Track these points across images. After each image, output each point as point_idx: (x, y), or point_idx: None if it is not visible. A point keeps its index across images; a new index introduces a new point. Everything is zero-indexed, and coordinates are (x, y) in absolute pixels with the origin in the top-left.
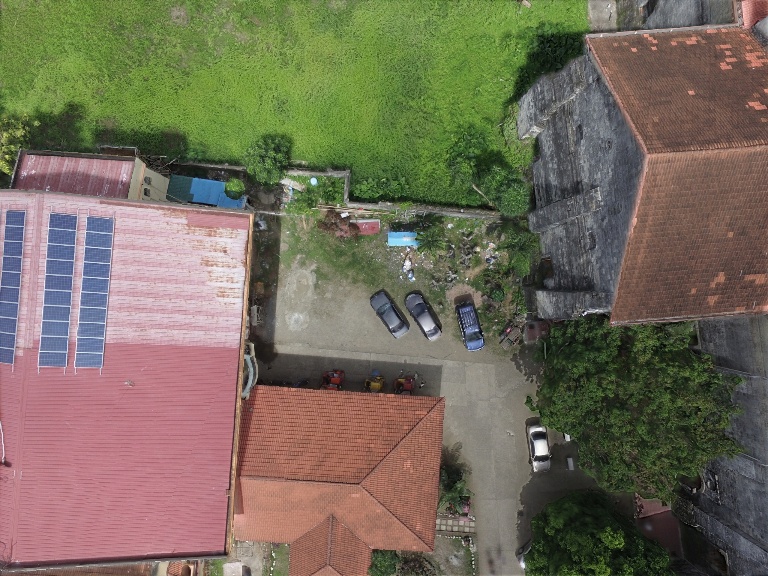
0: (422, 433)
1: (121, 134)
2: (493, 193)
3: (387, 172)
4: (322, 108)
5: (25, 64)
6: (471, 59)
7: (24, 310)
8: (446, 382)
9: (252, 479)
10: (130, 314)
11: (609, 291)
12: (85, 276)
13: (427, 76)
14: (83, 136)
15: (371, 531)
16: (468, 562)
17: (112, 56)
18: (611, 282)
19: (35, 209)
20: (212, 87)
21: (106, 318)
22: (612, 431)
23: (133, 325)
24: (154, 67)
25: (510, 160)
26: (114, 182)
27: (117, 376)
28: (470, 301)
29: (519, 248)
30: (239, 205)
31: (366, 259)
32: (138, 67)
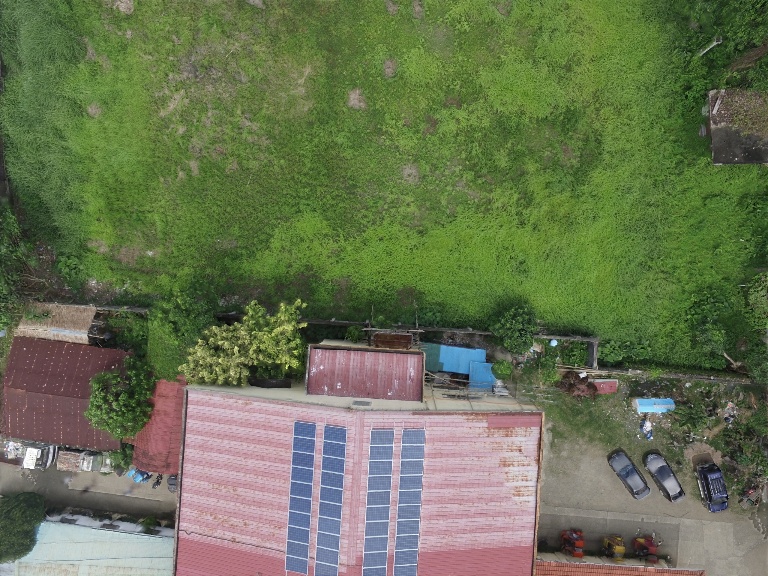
0: None
1: (357, 294)
2: None
3: (631, 336)
4: (561, 269)
5: (259, 224)
6: (709, 218)
7: (346, 526)
8: (684, 541)
9: None
10: (438, 522)
11: None
12: (401, 489)
13: (663, 234)
14: (320, 296)
15: None
16: None
17: (346, 215)
18: None
19: (356, 426)
20: (447, 246)
21: (419, 529)
22: None
23: (441, 532)
24: (389, 227)
25: (752, 321)
26: (403, 377)
27: None
28: (715, 464)
29: None
30: (493, 376)
31: (603, 418)
32: (372, 226)
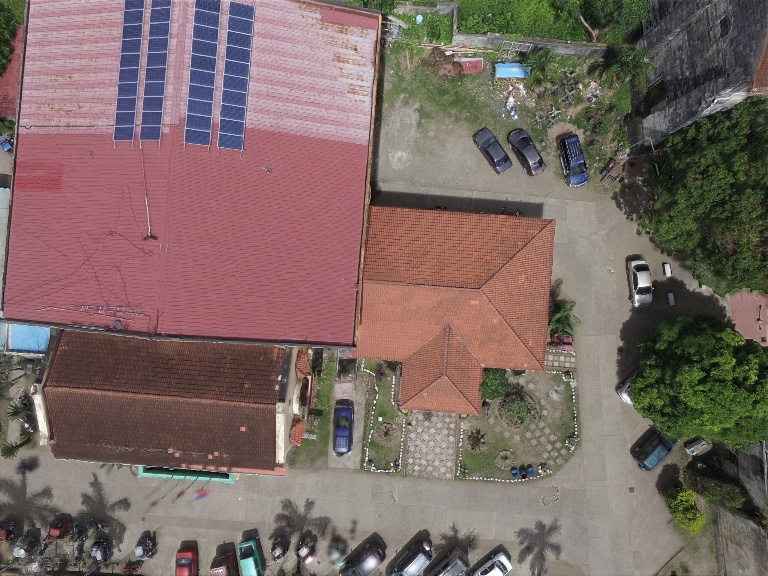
0: (535, 250)
1: None
2: (611, 6)
3: (493, 7)
4: None
5: None
6: None
7: (170, 89)
8: None
9: (375, 283)
10: (268, 102)
11: (748, 64)
12: (228, 59)
13: None
14: None
15: (485, 345)
16: (568, 397)
17: None
18: (751, 53)
19: None
20: None
21: (246, 102)
22: (742, 217)
23: (270, 113)
24: None
25: None
26: None
27: (255, 161)
28: None
29: (633, 66)
30: None
31: (469, 98)
32: None
